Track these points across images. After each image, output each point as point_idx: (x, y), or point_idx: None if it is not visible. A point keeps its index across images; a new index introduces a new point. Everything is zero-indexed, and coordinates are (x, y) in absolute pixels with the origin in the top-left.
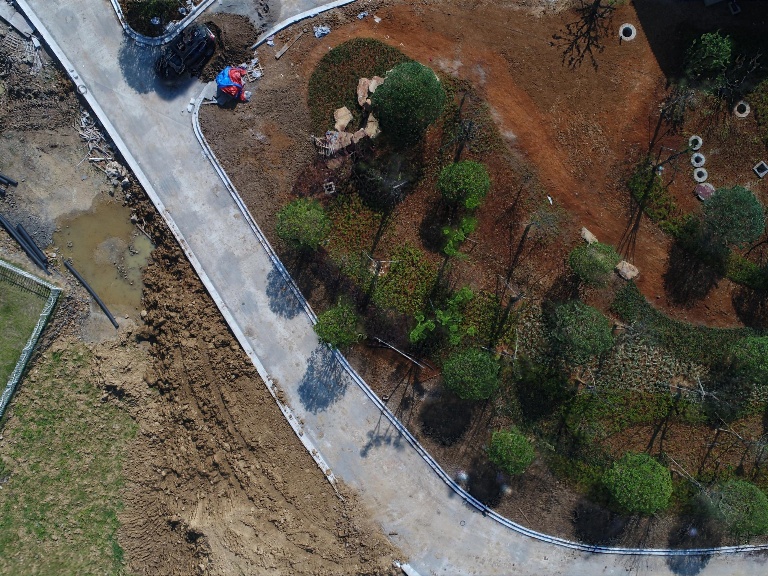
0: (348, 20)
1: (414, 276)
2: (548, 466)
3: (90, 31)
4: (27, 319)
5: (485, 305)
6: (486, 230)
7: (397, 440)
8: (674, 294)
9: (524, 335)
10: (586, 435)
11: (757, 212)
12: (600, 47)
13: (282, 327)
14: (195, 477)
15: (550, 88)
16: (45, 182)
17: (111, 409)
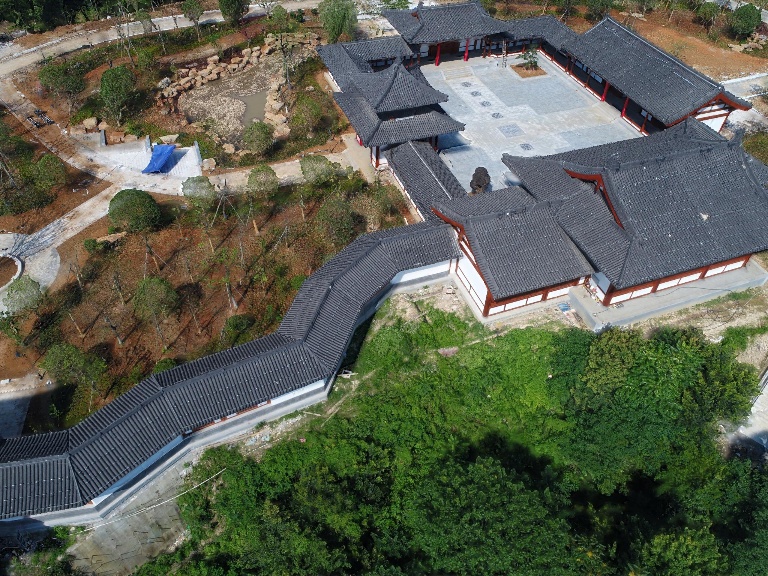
0: None
1: None
2: None
3: None
4: None
5: (675, 8)
6: None
7: None
8: None
9: None
10: None
11: None
12: None
13: None
14: None
15: None
16: None
17: None
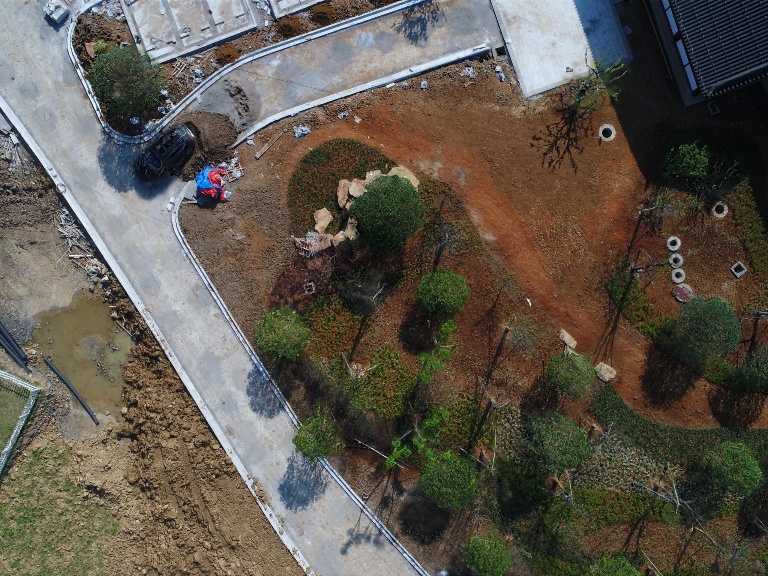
0: (328, 120)
1: (394, 379)
2: (526, 563)
3: (69, 129)
4: (7, 418)
5: (464, 407)
6: (465, 332)
7: (377, 538)
8: (651, 395)
9: (503, 436)
10: (564, 534)
11: (732, 326)
12: (580, 148)
13: (262, 426)
14: (176, 574)
15: (530, 190)
16: (24, 279)
17: (92, 507)
